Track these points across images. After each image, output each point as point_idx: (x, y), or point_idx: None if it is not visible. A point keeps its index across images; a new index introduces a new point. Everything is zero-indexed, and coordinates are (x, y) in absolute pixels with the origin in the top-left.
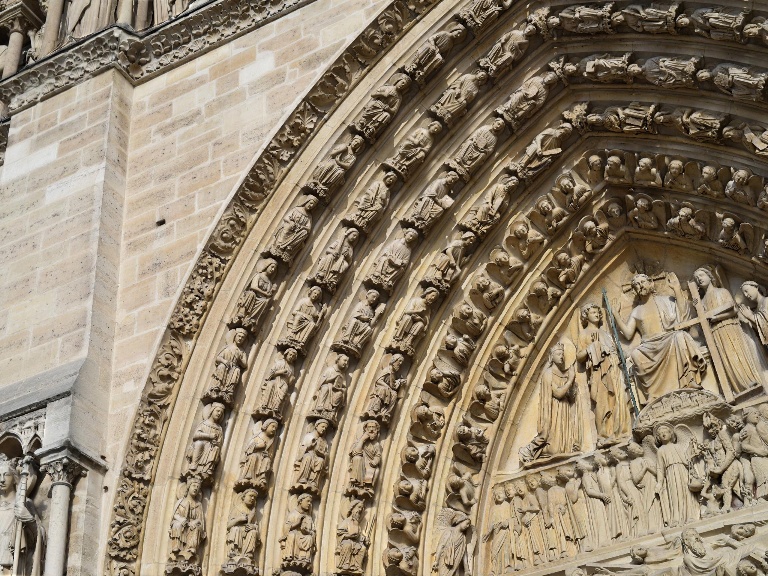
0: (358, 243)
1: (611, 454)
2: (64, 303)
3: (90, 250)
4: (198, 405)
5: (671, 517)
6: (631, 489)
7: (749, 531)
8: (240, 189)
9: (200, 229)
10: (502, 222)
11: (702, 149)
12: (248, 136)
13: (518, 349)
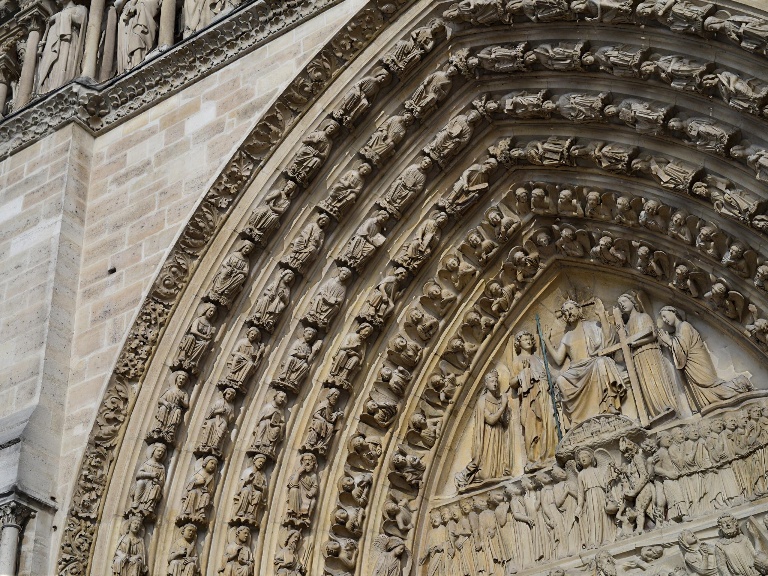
0: (295, 283)
1: (536, 479)
2: (21, 352)
3: (45, 301)
4: (142, 445)
5: (589, 539)
6: (554, 512)
7: (657, 553)
8: (181, 237)
9: (145, 277)
10: (434, 256)
11: (617, 180)
12: (190, 185)
13: (454, 378)
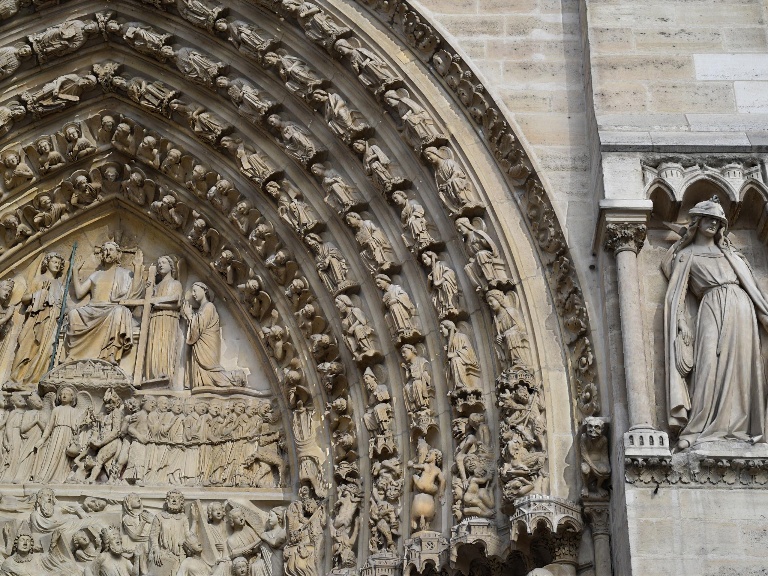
0: None
1: (11, 398)
2: None
3: None
4: None
5: (39, 473)
6: (15, 436)
7: (99, 506)
8: None
9: None
10: None
11: (203, 148)
12: None
13: None
